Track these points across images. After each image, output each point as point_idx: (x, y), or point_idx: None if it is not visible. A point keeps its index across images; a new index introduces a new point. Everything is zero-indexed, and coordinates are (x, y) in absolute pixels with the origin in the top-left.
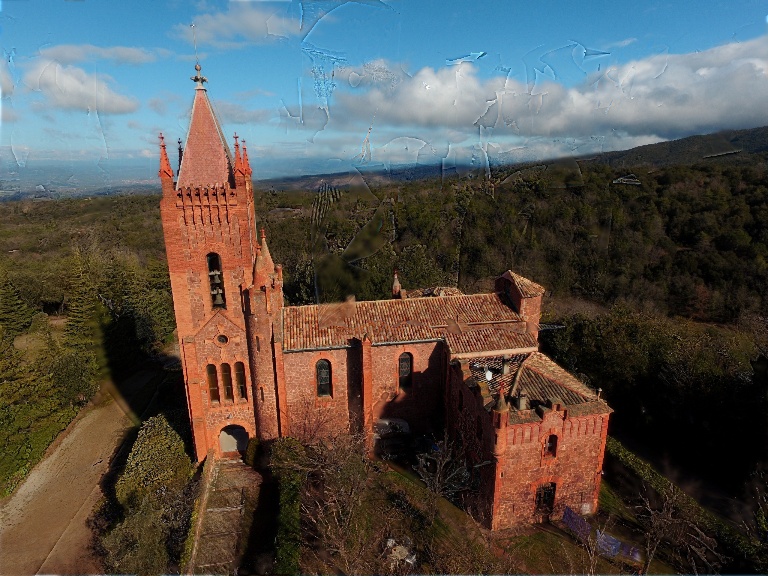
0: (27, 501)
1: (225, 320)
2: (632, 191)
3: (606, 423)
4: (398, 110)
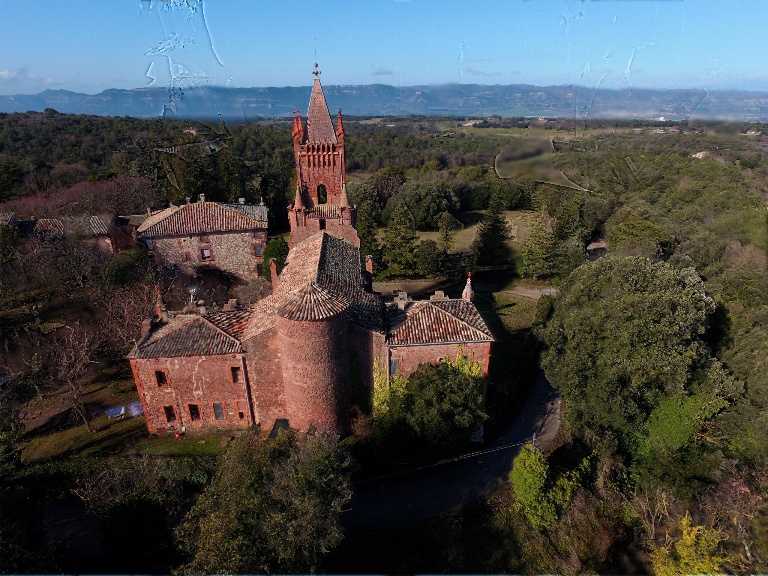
0: None
1: None
2: None
3: None
4: None
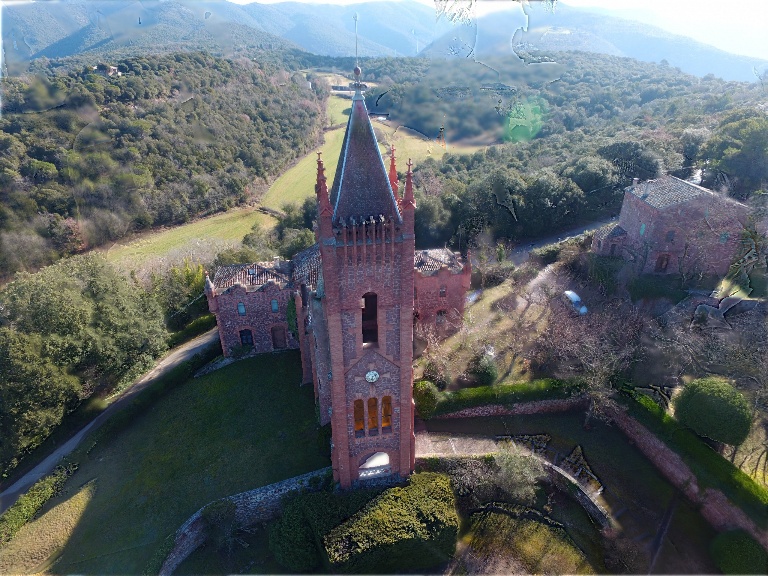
0: None
1: None
2: None
3: None
4: (404, 110)
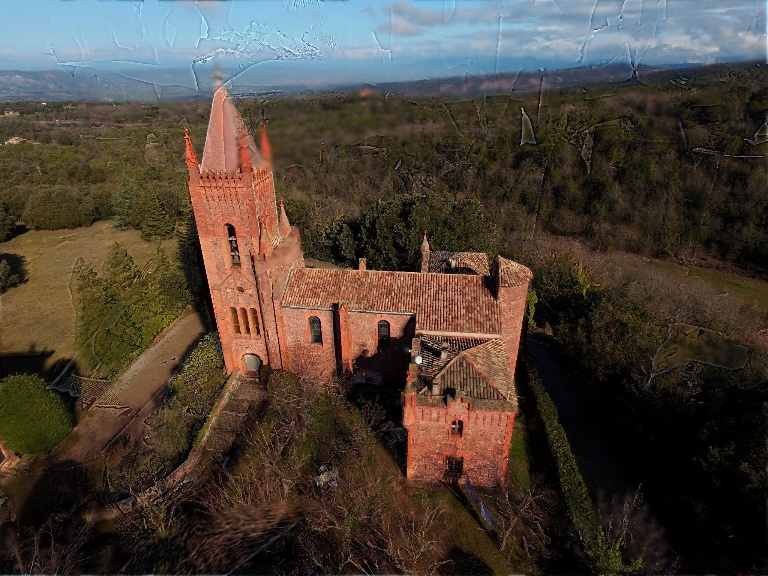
0: (134, 375)
1: (241, 276)
2: (766, 145)
3: (511, 420)
4: (363, 116)
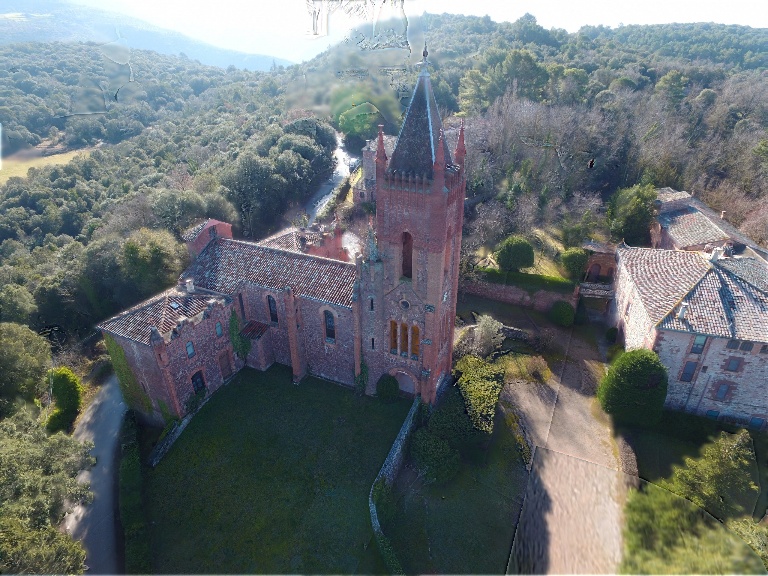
0: None
1: None
2: None
3: None
4: (318, 92)
